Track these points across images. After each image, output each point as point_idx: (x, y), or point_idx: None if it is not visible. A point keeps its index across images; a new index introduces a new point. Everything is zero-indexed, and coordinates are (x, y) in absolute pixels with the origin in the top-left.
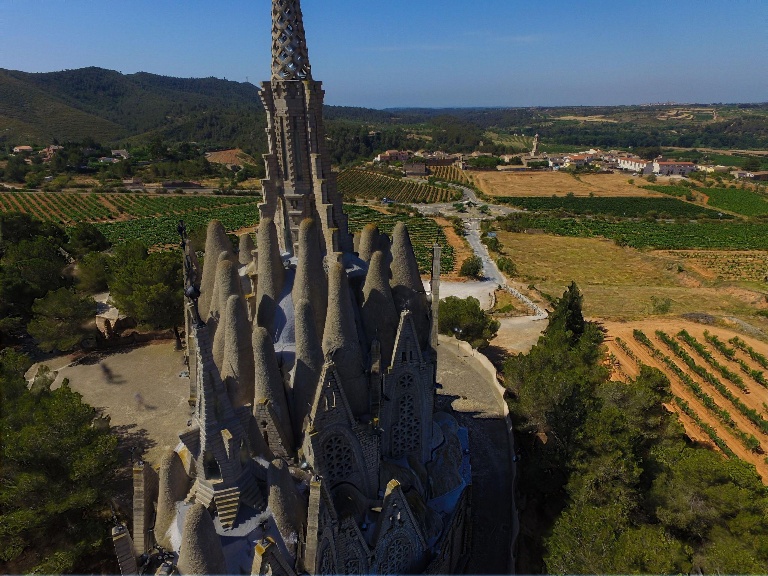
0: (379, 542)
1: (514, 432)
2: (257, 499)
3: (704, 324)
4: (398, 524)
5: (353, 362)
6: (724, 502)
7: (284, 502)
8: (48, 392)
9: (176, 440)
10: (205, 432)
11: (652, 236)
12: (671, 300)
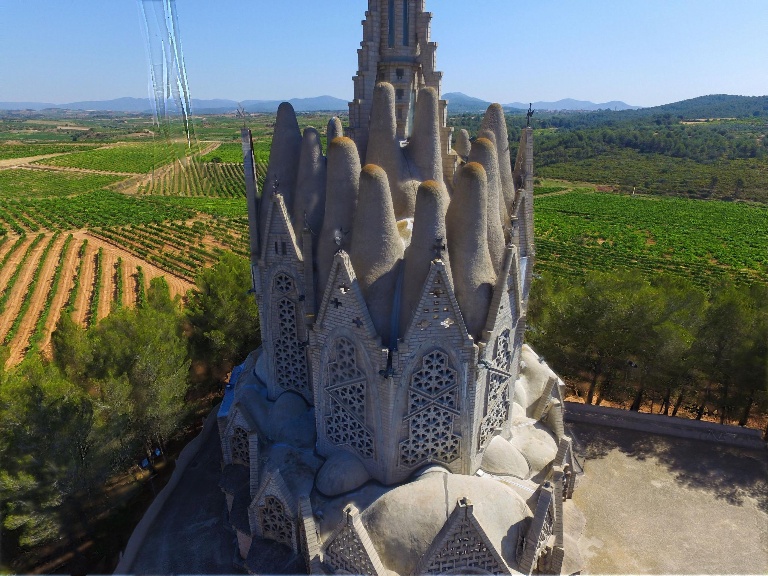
0: None
1: None
2: None
3: None
4: None
5: None
6: None
7: None
8: (767, 363)
9: (664, 496)
10: None
11: None
12: None
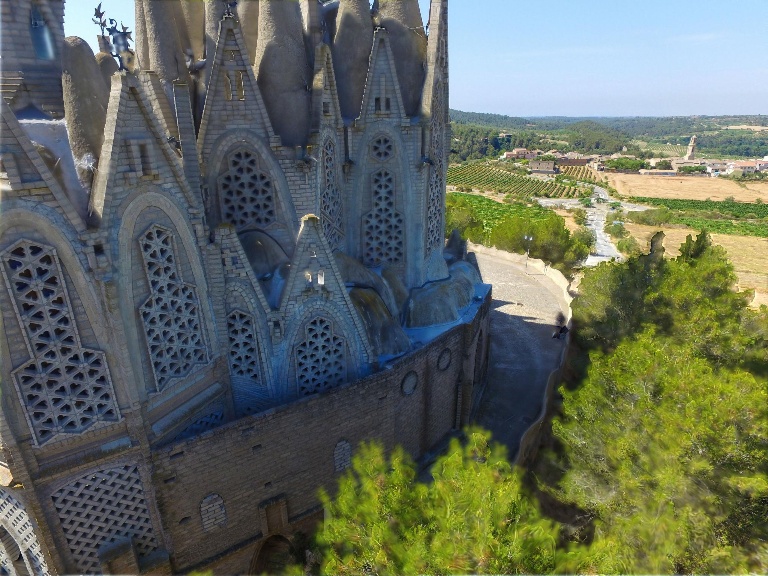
0: (287, 304)
1: (573, 337)
2: (52, 103)
3: None
4: (319, 290)
5: (288, 67)
6: None
7: (78, 102)
8: None
9: None
10: None
11: None
12: None
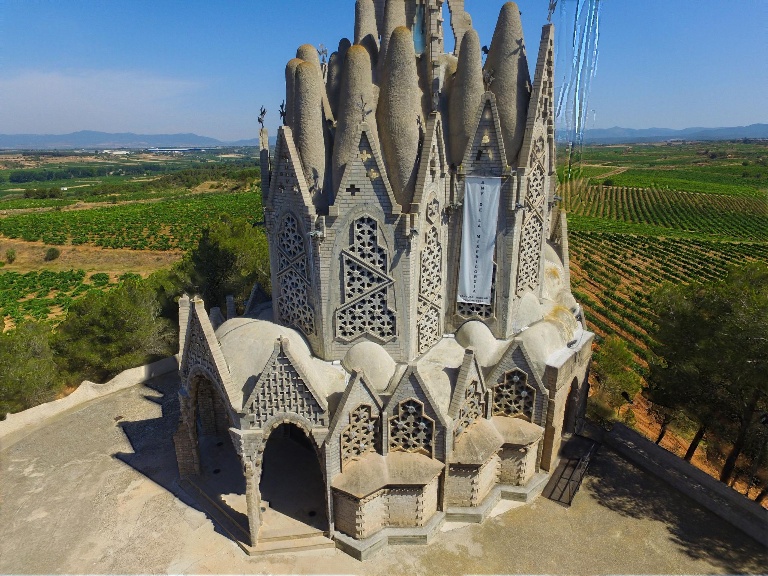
0: None
1: None
2: None
3: None
4: None
5: None
6: None
7: None
8: None
9: None
10: None
11: None
12: None
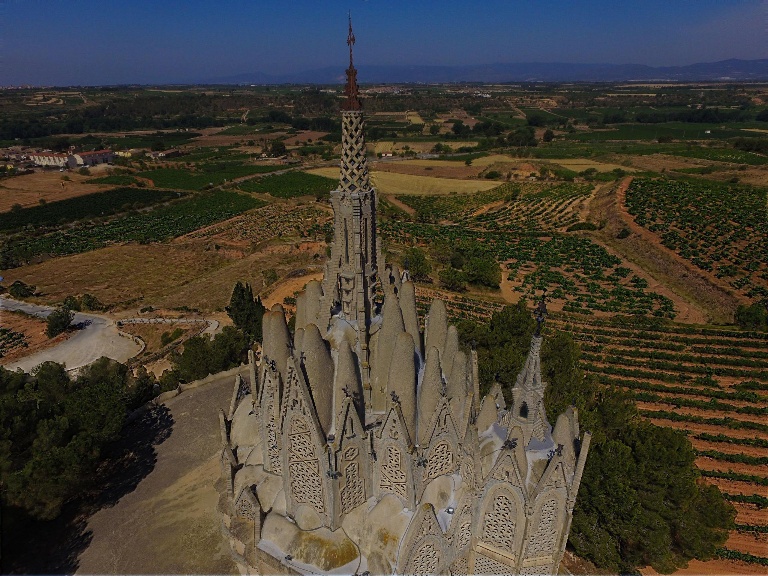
0: None
1: None
2: None
3: (303, 276)
4: None
5: None
6: (481, 335)
7: None
8: None
9: None
10: (542, 389)
11: (153, 227)
12: (274, 269)
